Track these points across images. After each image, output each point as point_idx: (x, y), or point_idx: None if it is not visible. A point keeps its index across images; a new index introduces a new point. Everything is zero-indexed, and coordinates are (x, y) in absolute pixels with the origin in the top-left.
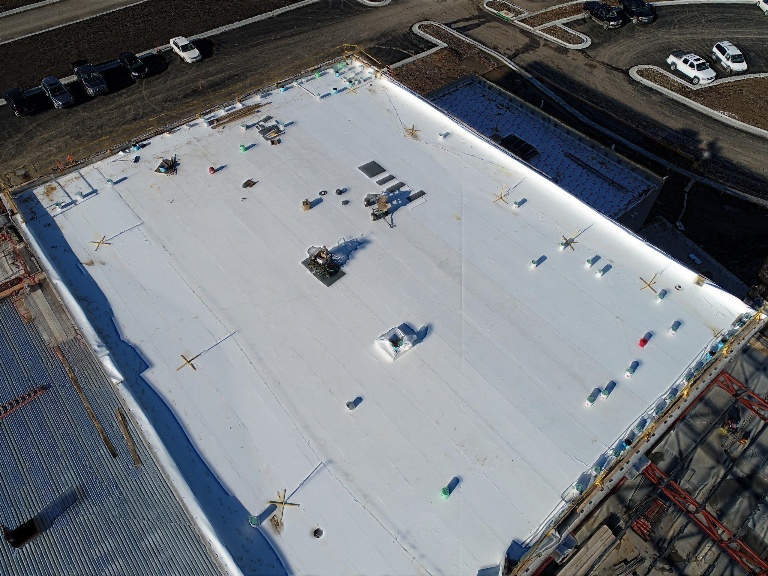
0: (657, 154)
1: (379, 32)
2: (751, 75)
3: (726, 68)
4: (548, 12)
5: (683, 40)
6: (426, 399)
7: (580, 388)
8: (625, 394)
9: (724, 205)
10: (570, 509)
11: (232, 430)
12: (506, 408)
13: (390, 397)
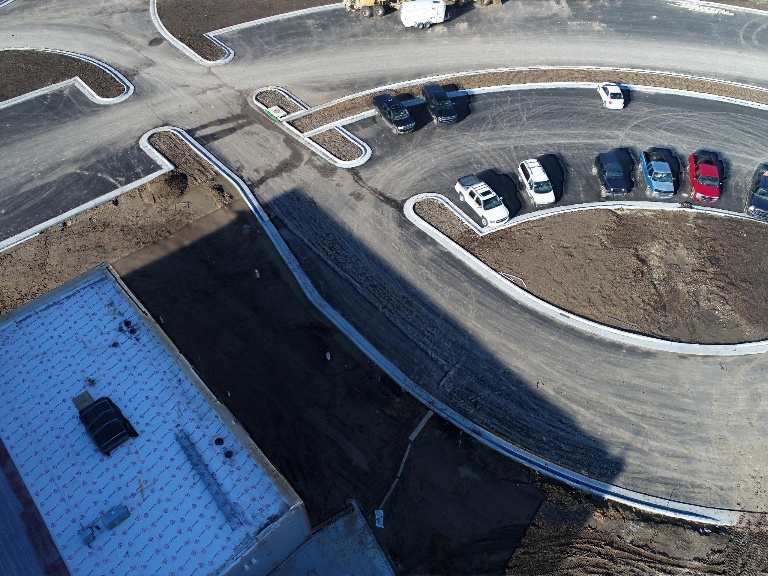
0: (395, 360)
1: (92, 147)
2: (561, 208)
3: (530, 198)
4: (332, 107)
5: (490, 149)
6: None
7: None
8: None
9: (460, 466)
10: None
11: None
12: None
13: None
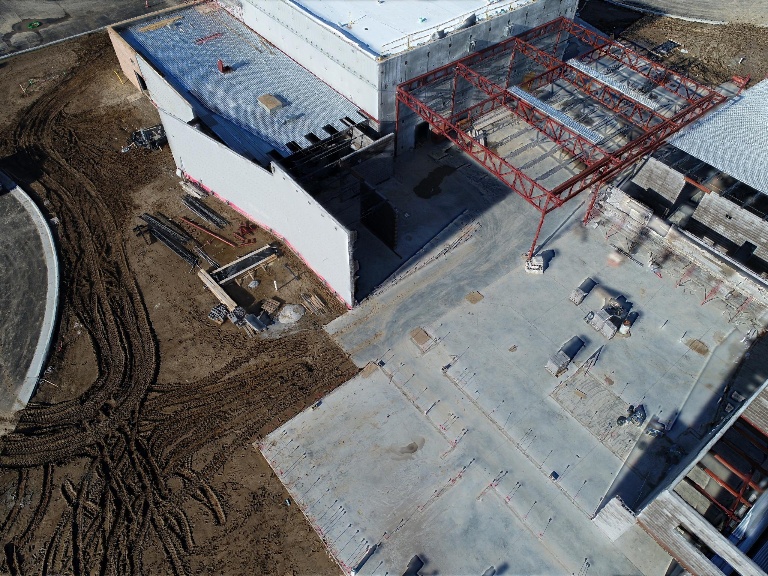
0: None
1: None
2: None
3: None
4: None
5: None
6: (414, 2)
7: (485, 1)
8: (506, 3)
9: (609, 8)
10: (471, 12)
11: (326, 8)
12: (450, 4)
13: (397, 1)
